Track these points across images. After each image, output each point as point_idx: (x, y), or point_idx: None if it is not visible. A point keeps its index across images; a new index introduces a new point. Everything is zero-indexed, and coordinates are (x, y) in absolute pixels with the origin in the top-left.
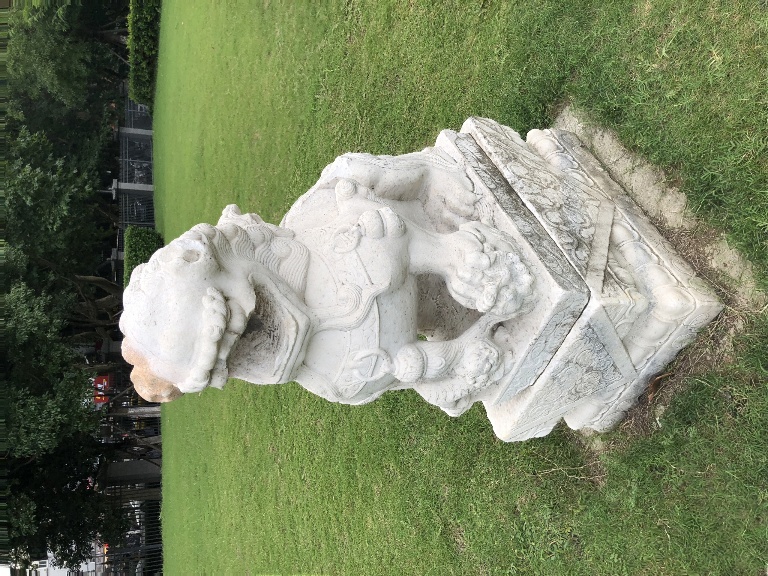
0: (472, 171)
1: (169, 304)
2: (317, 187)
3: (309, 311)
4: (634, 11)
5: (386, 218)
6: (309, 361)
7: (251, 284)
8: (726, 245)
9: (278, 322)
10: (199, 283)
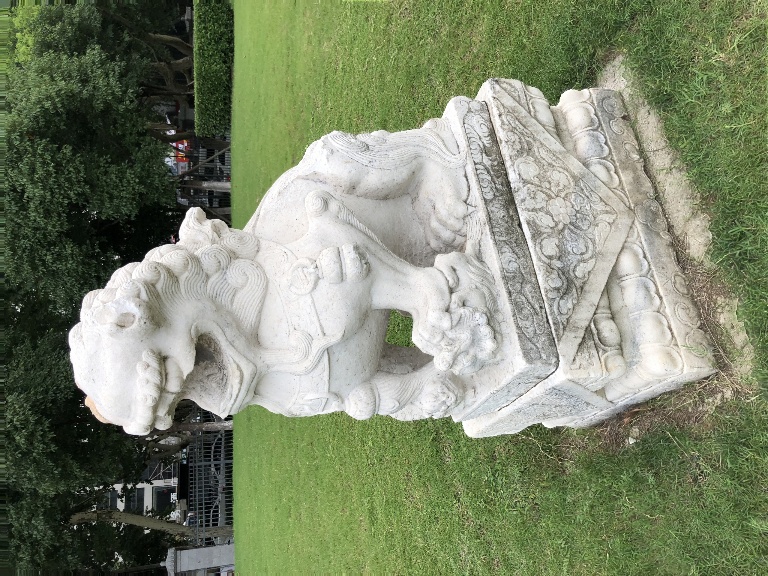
0: (471, 170)
1: (105, 366)
2: (295, 176)
3: (257, 357)
4: None
5: (346, 263)
6: (262, 391)
7: (193, 338)
8: None
9: (226, 365)
10: (135, 346)
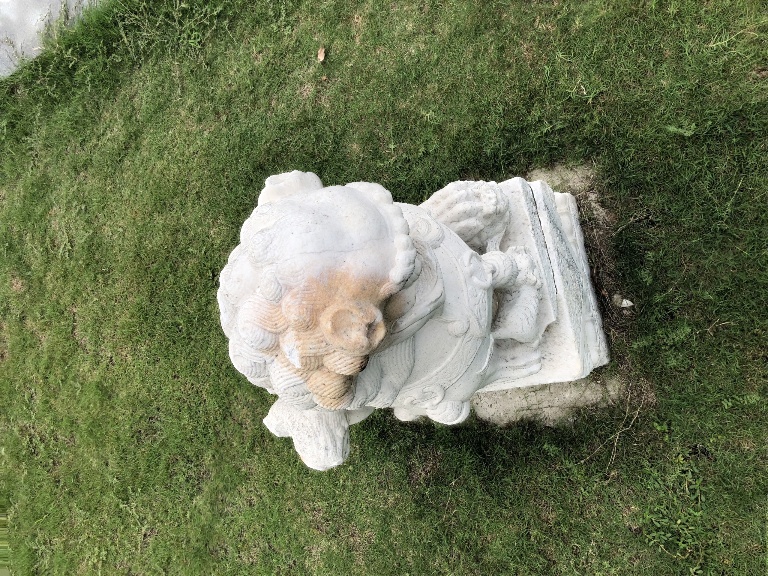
0: None
1: (322, 200)
2: None
3: None
4: (348, 157)
5: None
6: None
7: None
8: (536, 178)
9: None
10: None
